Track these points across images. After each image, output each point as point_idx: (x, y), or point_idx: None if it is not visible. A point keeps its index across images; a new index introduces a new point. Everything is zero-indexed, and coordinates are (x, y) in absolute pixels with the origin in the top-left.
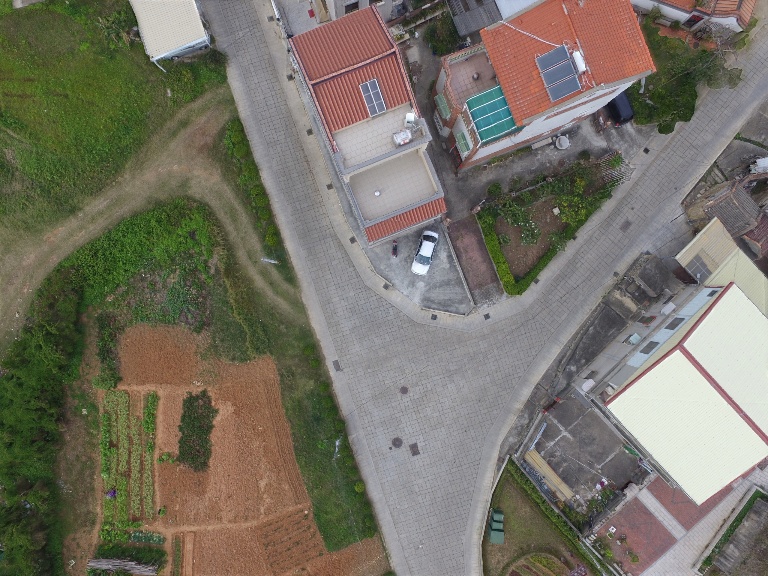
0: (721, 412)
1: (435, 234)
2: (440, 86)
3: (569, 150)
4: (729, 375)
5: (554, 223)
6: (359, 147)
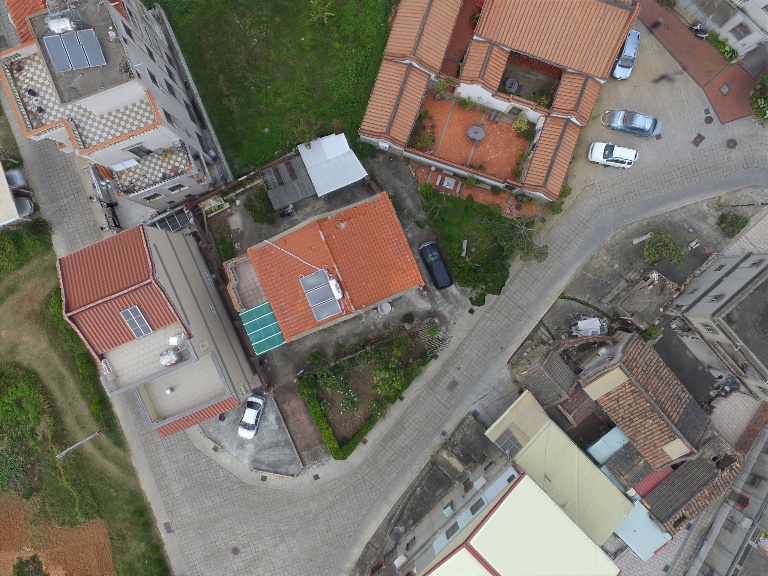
0: None
1: (259, 400)
2: None
3: (393, 313)
4: (518, 570)
5: None
6: (131, 364)
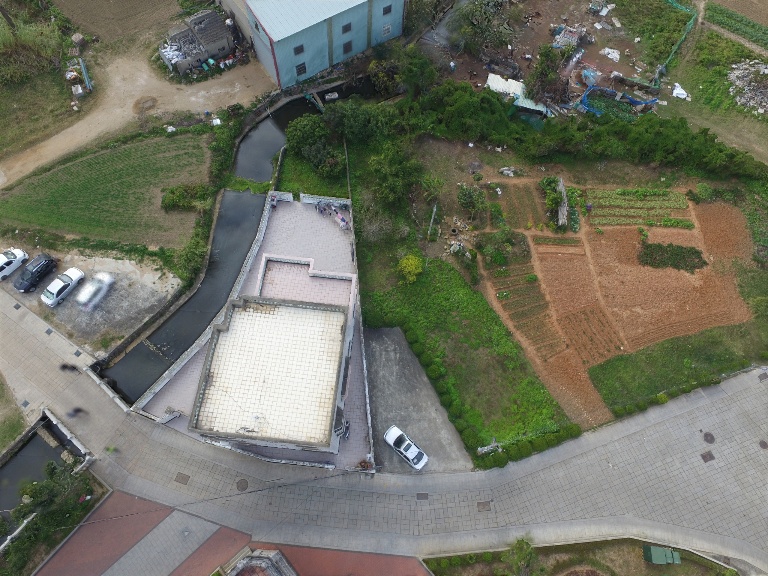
0: None
1: None
2: None
3: None
4: None
5: None
6: None
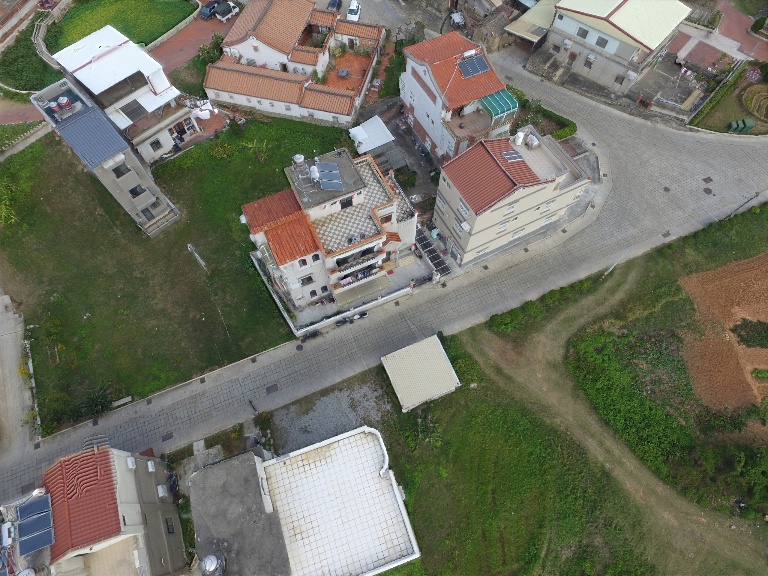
0: (636, 1)
1: None
2: None
3: None
4: (613, 0)
5: (517, 113)
6: (543, 169)
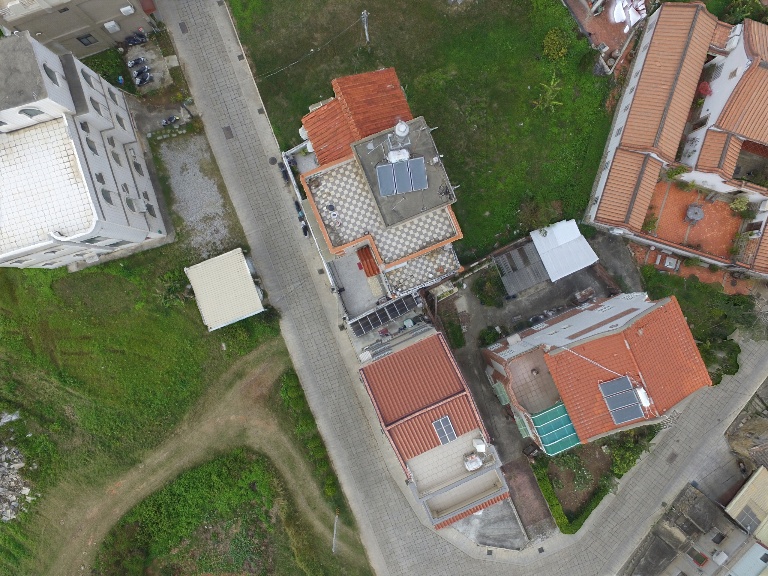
0: None
1: None
2: (497, 367)
3: None
4: None
5: (603, 458)
6: (430, 468)
